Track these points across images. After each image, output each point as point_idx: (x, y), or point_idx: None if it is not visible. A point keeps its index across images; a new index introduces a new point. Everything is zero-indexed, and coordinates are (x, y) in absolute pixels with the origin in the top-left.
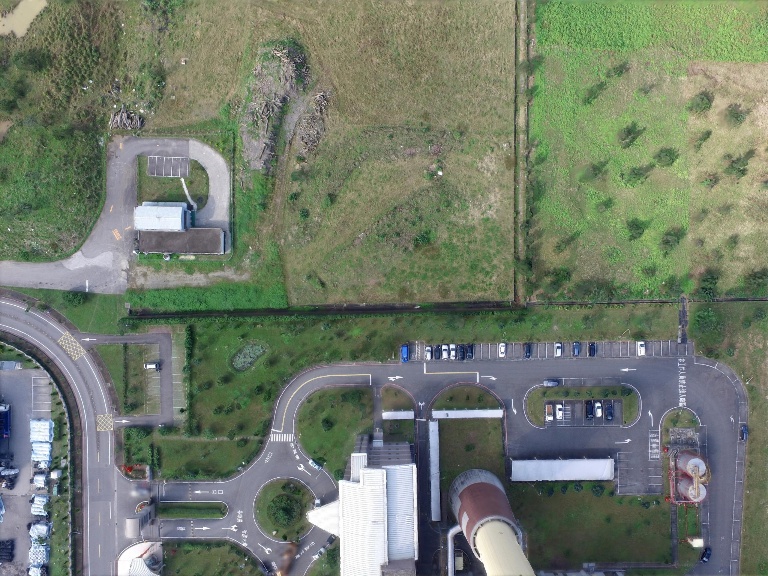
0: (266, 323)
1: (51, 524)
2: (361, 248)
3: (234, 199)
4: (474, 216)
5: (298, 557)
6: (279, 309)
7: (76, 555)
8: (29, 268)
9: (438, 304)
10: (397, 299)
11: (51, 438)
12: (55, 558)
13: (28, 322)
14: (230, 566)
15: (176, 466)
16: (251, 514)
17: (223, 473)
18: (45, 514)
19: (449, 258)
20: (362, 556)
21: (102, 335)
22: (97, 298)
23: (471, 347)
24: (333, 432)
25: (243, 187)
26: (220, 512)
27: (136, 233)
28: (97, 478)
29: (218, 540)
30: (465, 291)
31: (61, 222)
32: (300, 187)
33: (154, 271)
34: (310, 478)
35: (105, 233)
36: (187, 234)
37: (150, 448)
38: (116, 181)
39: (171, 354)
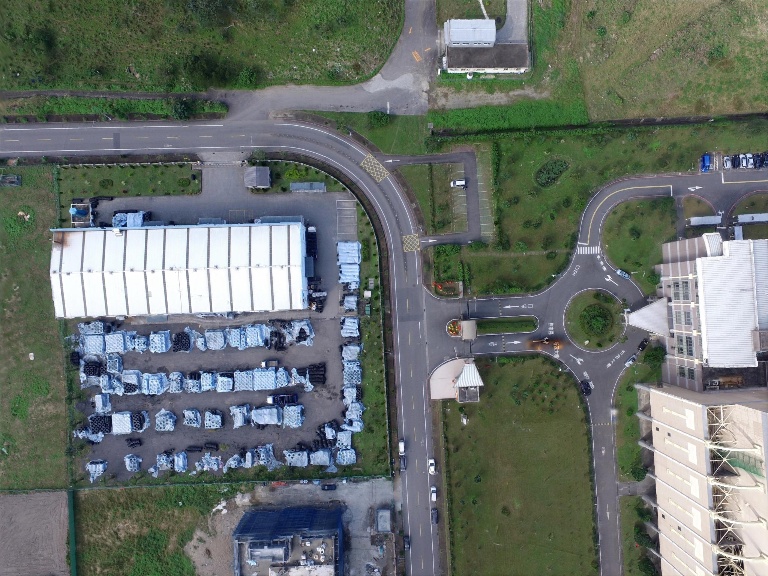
0: (568, 139)
1: (362, 345)
2: (658, 63)
3: (532, 19)
4: (762, 31)
5: (609, 366)
6: (579, 126)
7: (388, 375)
8: (329, 92)
9: (731, 117)
10: (693, 112)
11: (359, 259)
12: (367, 379)
13: (330, 145)
14: (544, 378)
15: (485, 282)
16: (562, 326)
17: (533, 287)
18: (357, 335)
19: (742, 71)
20: (730, 325)
21: (405, 156)
22: (399, 120)
23: (767, 156)
24: (639, 242)
25: (542, 6)
26: (533, 324)
27: (436, 54)
28: (406, 298)
29: (530, 353)
30: (758, 102)
31: (366, 41)
32: (596, 5)
33: (455, 91)
34: (618, 288)
35: (405, 55)
36: (494, 49)
37: (461, 264)
38: (414, 3)
39: (476, 172)
